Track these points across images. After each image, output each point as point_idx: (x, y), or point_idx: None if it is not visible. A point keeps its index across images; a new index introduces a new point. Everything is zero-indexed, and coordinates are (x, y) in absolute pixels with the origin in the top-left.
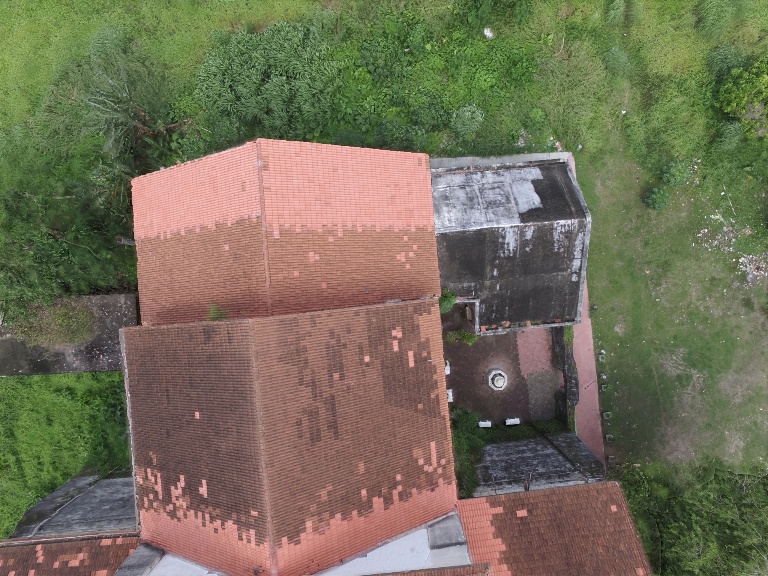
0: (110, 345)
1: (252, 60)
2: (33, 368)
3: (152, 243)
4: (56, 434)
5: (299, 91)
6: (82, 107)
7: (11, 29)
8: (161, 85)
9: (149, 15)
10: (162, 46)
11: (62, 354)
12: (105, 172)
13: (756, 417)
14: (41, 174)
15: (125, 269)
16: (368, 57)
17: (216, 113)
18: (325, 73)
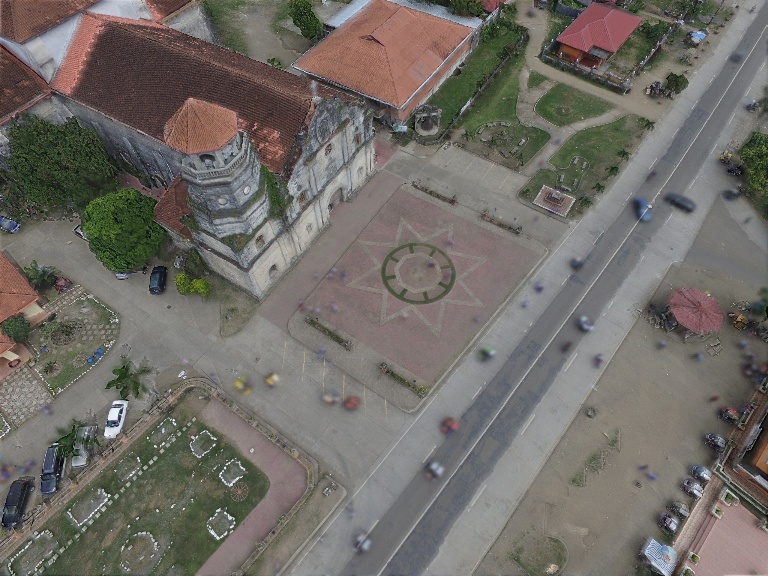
0: None
1: None
2: None
3: None
4: None
5: None
6: None
7: None
8: None
9: None
10: None
11: None
12: None
13: (224, 2)
14: None
15: None
16: None
17: None
18: None
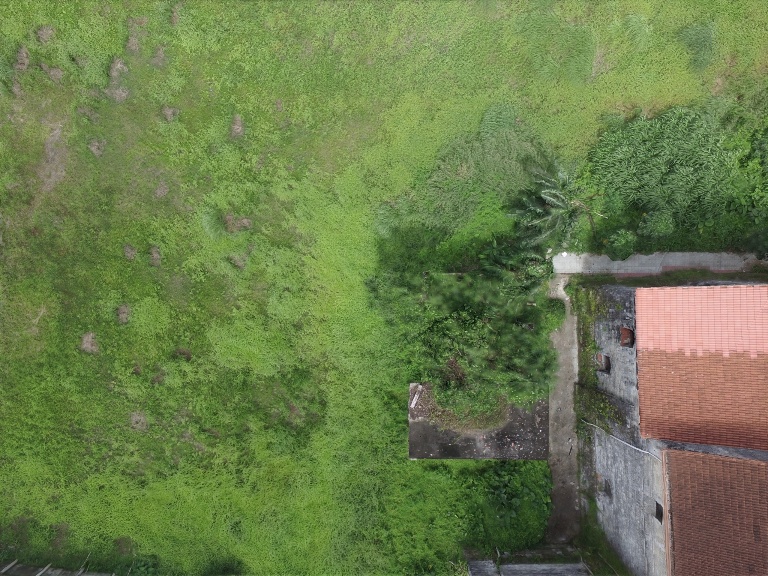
0: (522, 433)
1: (656, 148)
2: (443, 452)
3: (668, 357)
4: (429, 511)
5: (701, 182)
6: (469, 184)
7: (395, 100)
8: (550, 166)
9: (535, 93)
10: (547, 125)
11: (473, 439)
12: (539, 262)
13: None
14: (424, 249)
15: (510, 350)
16: (766, 149)
17: (617, 200)
18: (724, 164)
